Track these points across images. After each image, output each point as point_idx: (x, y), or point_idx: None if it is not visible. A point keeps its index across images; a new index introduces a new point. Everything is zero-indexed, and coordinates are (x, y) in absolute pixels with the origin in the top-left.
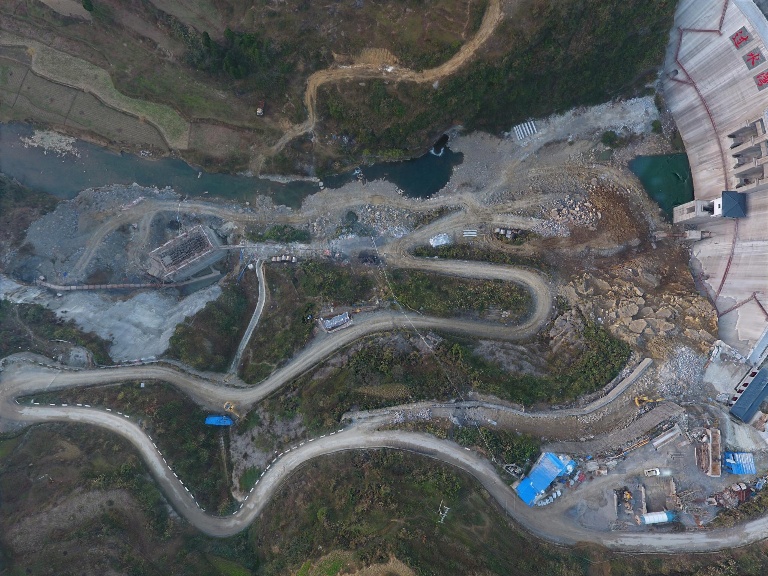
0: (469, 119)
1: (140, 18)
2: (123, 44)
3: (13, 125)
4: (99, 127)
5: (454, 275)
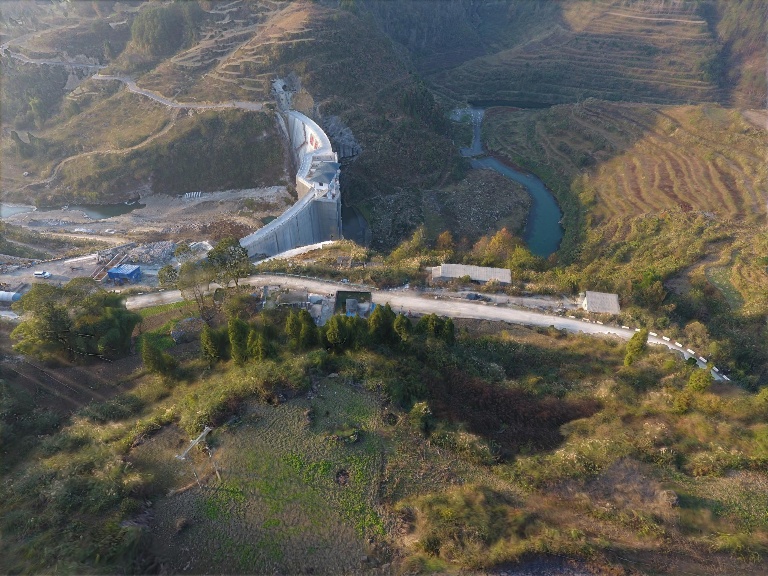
0: (153, 183)
1: None
2: None
3: None
4: None
5: None
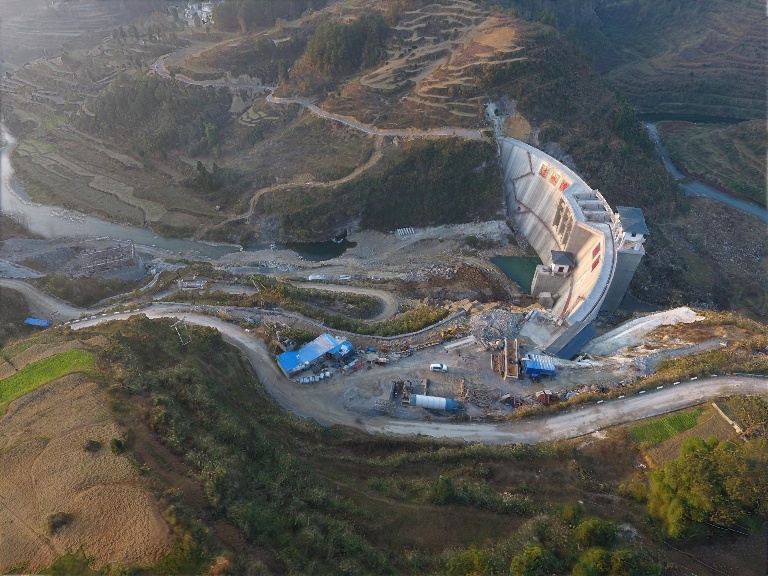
0: (362, 218)
1: (170, 168)
2: (152, 178)
3: (54, 207)
4: (107, 209)
5: None
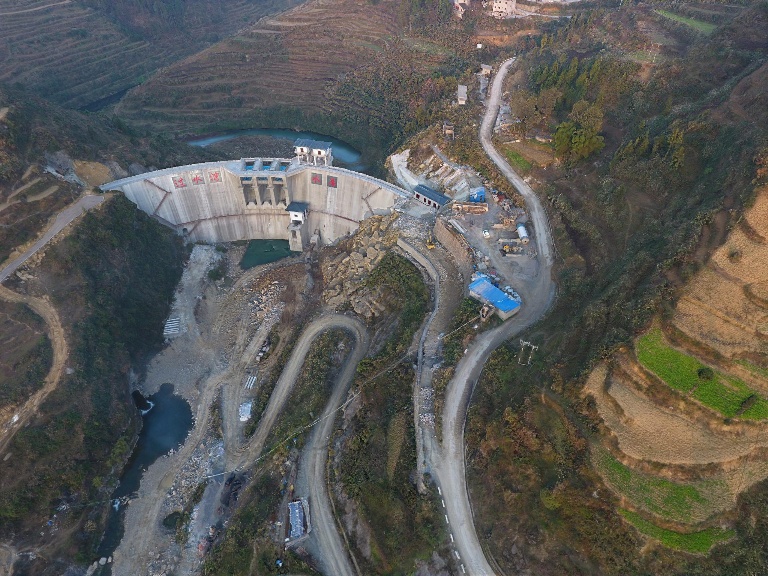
0: None
1: None
2: None
3: None
4: None
5: (288, 396)
